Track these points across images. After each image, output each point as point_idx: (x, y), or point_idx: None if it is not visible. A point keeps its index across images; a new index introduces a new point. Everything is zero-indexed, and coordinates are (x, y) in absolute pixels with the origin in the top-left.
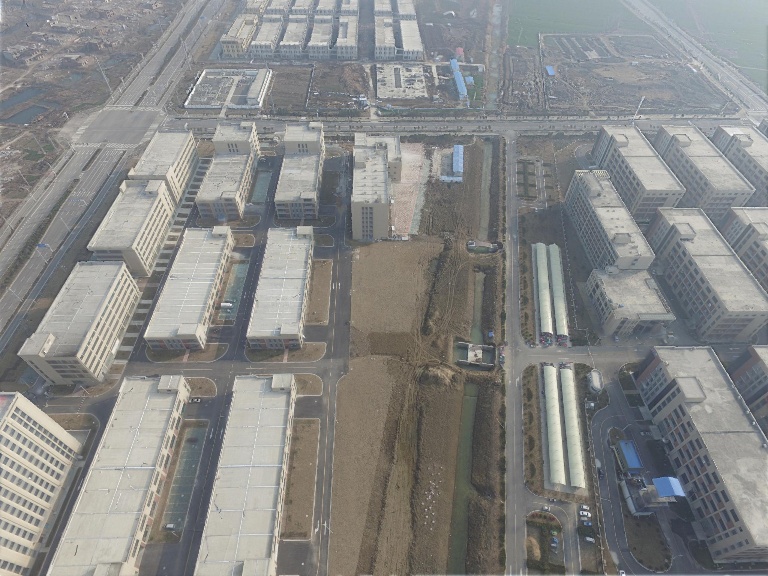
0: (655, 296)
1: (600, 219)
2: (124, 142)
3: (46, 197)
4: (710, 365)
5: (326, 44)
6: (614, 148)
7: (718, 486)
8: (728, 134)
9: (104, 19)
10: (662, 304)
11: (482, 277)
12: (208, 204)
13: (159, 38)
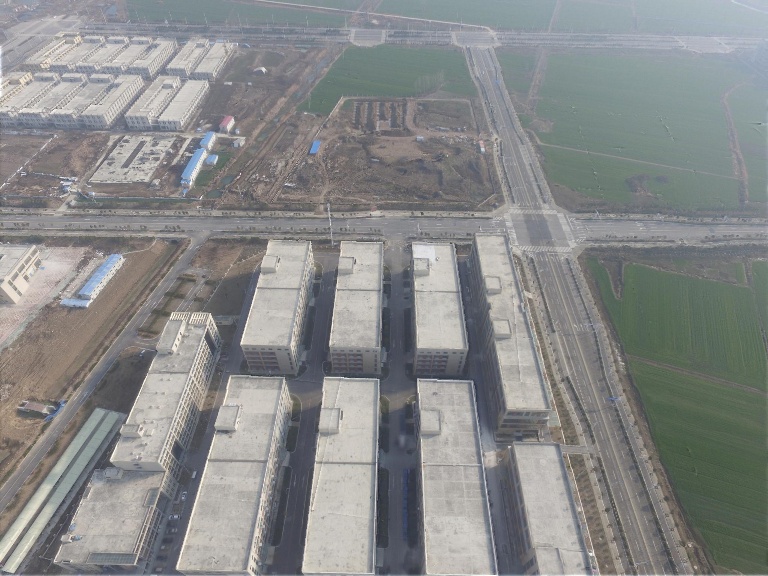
0: (139, 520)
1: (141, 393)
2: None
3: None
4: None
5: (70, 112)
6: None
7: None
8: None
9: None
10: (138, 535)
11: (2, 458)
12: None
13: None
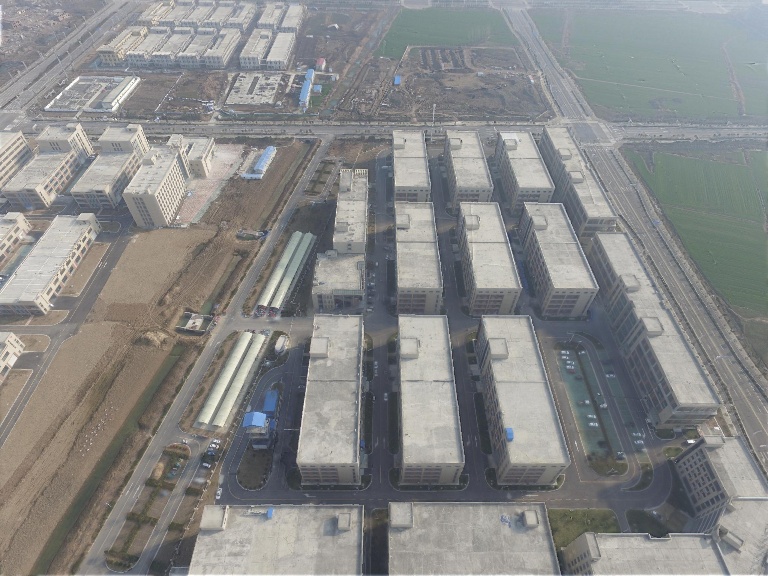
0: (358, 276)
1: (337, 210)
2: None
3: None
4: (354, 329)
5: (194, 54)
6: (393, 150)
7: None
8: (502, 139)
9: (10, 29)
10: (360, 282)
11: (238, 260)
12: (13, 194)
13: None
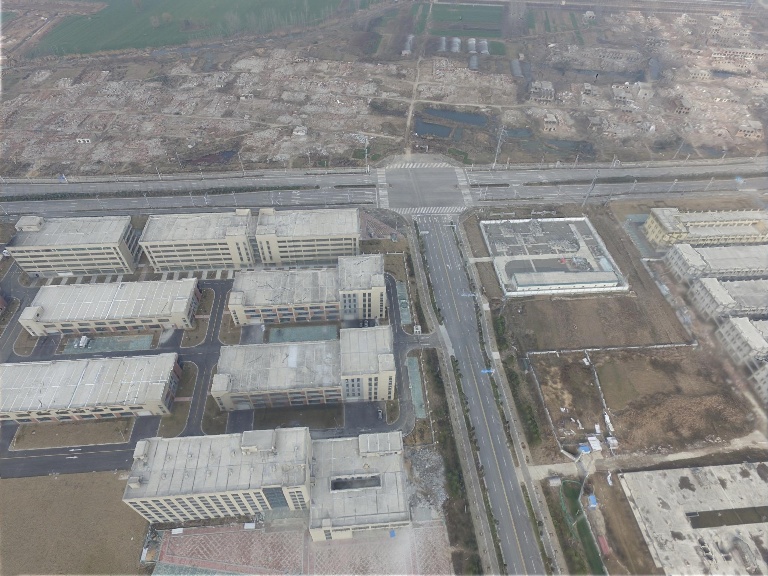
0: None
1: None
2: (391, 197)
3: (292, 178)
4: None
5: (756, 345)
6: None
7: None
8: None
9: (668, 111)
10: None
11: None
12: None
13: (654, 160)
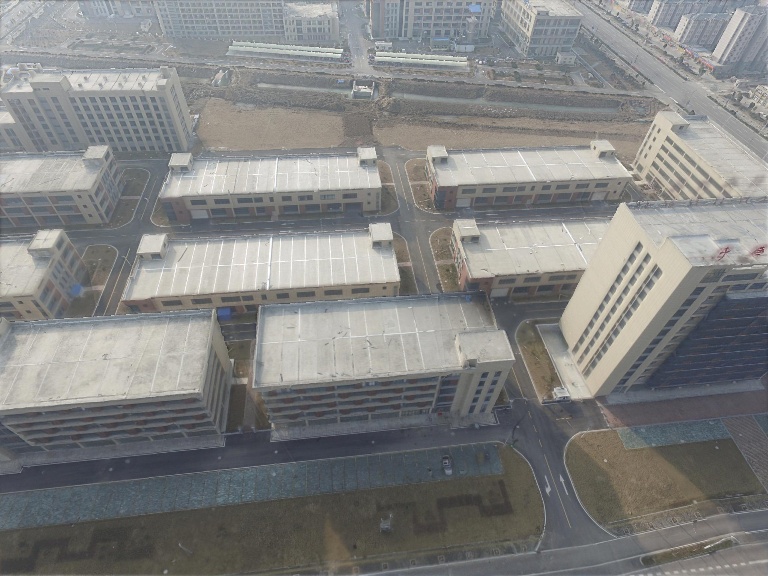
0: (314, 5)
1: None
2: None
3: None
4: None
5: None
6: None
7: (463, 5)
8: None
9: None
10: (322, 4)
11: (265, 84)
12: (48, 283)
13: None
